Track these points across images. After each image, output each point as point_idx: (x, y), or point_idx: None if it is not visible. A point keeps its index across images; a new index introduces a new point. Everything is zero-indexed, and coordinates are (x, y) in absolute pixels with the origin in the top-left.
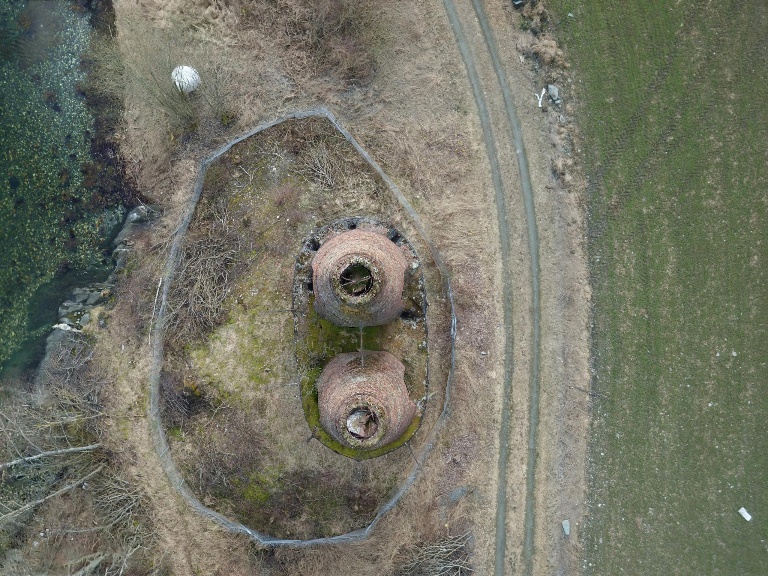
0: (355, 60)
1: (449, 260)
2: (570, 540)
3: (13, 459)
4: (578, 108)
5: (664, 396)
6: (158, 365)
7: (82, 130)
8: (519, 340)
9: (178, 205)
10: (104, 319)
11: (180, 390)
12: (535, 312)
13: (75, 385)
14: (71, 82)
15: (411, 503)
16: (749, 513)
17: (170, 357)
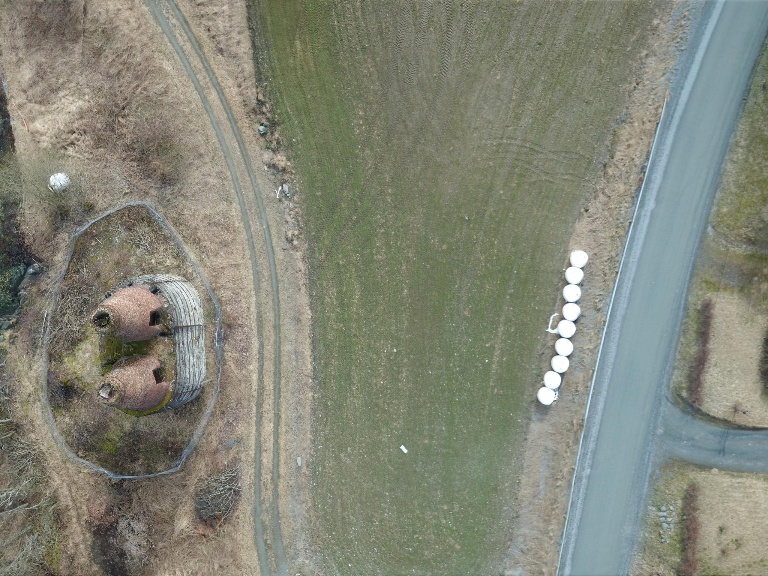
0: (164, 169)
1: (221, 297)
2: (302, 469)
3: None
4: (301, 199)
5: (355, 378)
6: (46, 367)
7: None
8: (267, 345)
9: (58, 263)
10: (13, 338)
11: None
12: (277, 328)
13: None
14: None
15: (204, 449)
16: (406, 448)
17: (53, 362)
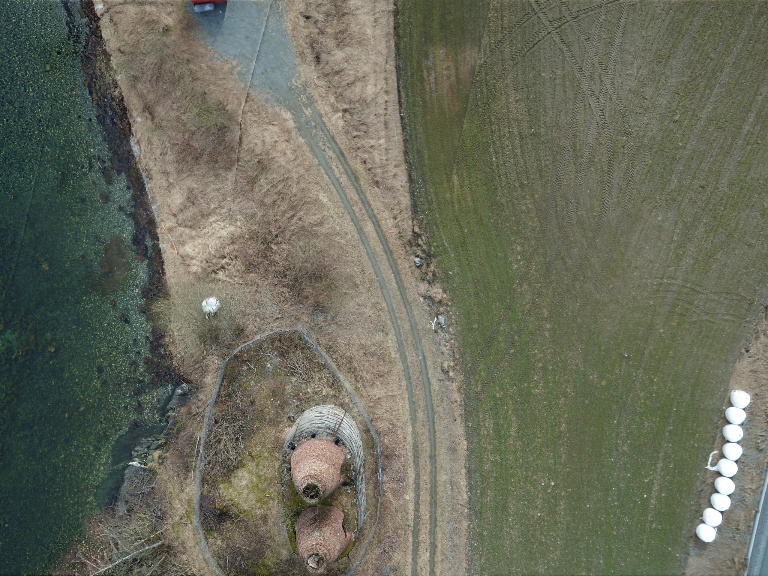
0: (318, 298)
1: (378, 428)
2: None
3: (117, 560)
4: (457, 330)
5: (512, 509)
6: (199, 491)
7: (144, 335)
8: (423, 475)
9: (208, 386)
10: (162, 459)
11: (213, 508)
12: (433, 458)
13: (145, 503)
14: (136, 304)
15: None
16: None
17: (206, 486)
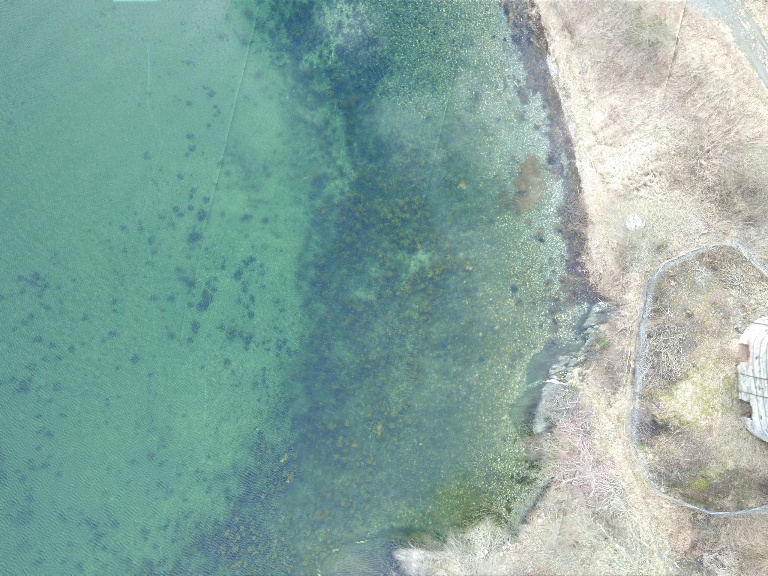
0: (754, 212)
1: None
2: None
3: None
4: None
5: None
6: (630, 405)
7: (559, 254)
8: None
9: (631, 302)
10: (582, 376)
11: (650, 421)
12: None
13: (571, 419)
14: (551, 223)
15: None
16: None
17: (638, 400)
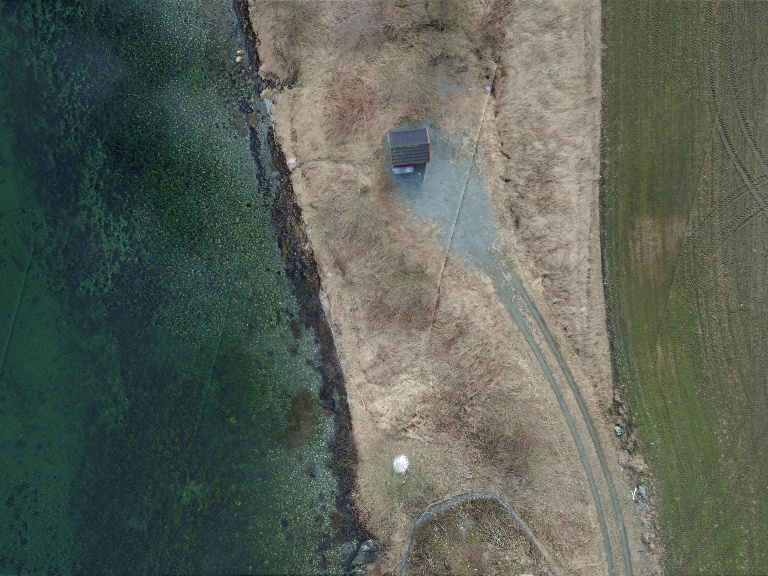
0: (514, 463)
1: None
2: None
3: None
4: (658, 502)
5: None
6: None
7: (329, 490)
8: None
9: (396, 544)
10: None
11: None
12: None
13: None
14: (322, 458)
15: None
16: None
17: None
